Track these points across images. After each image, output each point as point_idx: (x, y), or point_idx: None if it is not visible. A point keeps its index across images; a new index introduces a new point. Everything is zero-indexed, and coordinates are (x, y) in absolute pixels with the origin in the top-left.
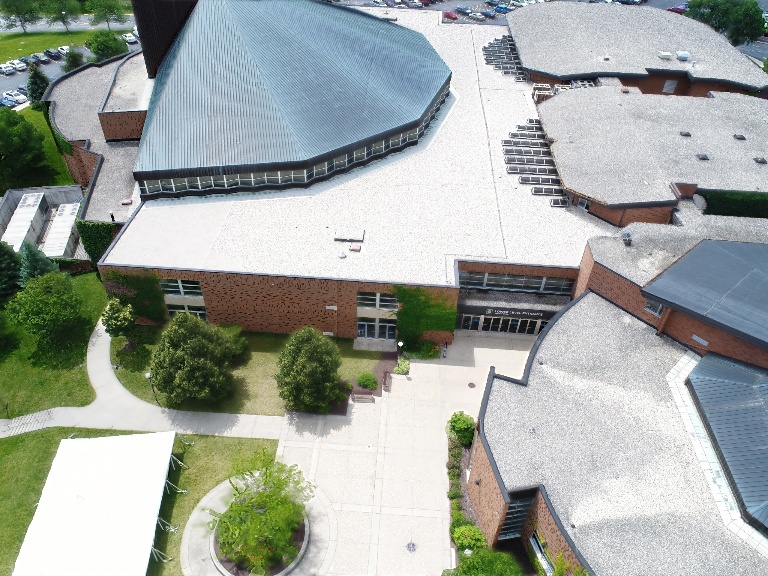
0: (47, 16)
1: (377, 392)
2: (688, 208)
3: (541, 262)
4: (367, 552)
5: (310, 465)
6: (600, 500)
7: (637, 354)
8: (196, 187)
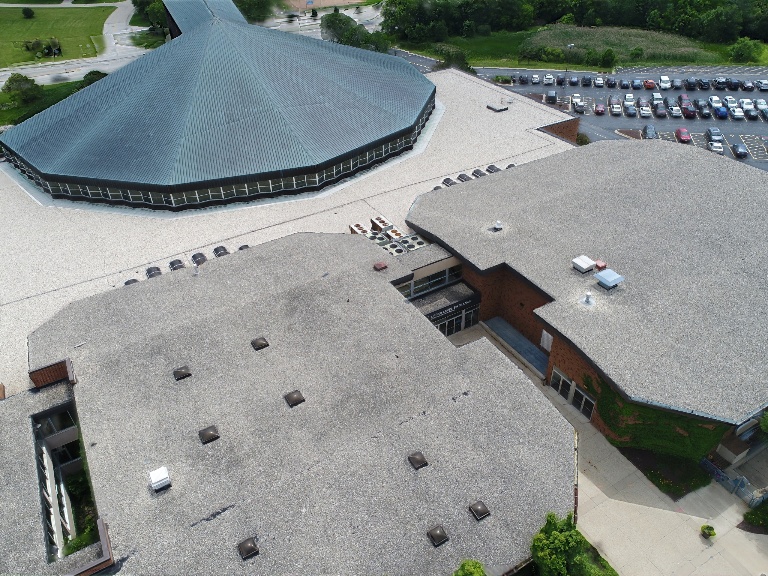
0: (346, 43)
1: None
2: (45, 399)
3: None
4: None
5: None
6: None
7: None
8: None
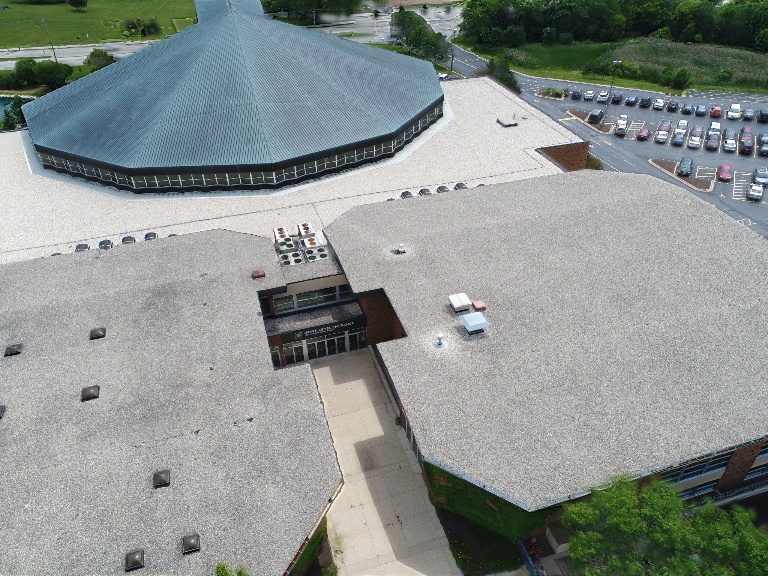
0: (412, 43)
1: None
2: None
3: None
4: None
5: None
6: None
7: None
8: None
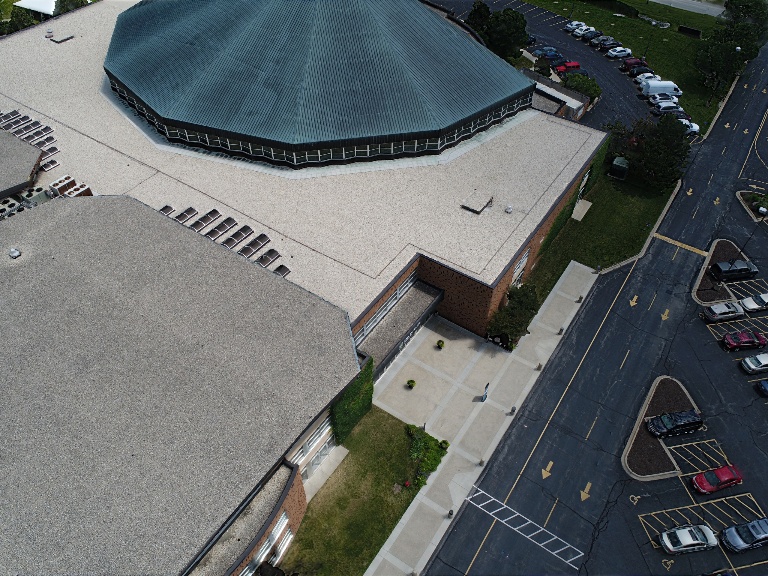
0: None
1: None
2: None
3: None
4: None
5: None
6: None
7: None
8: None
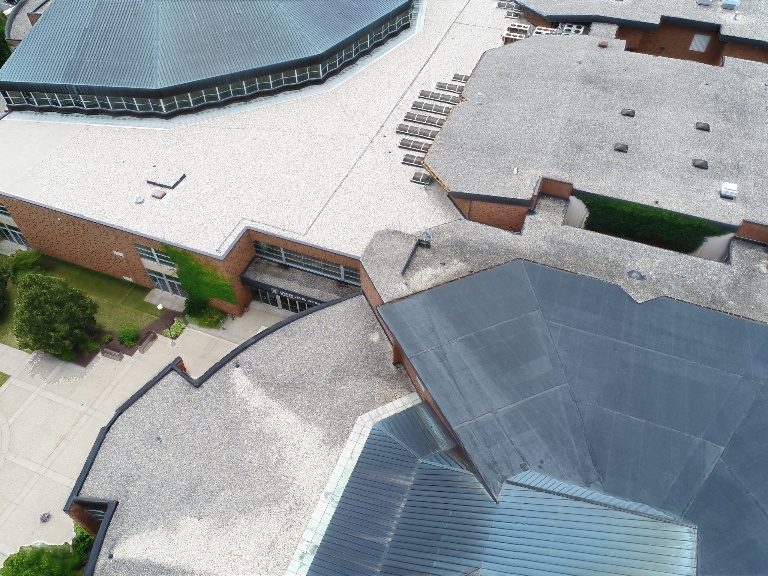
0: None
1: (131, 351)
2: (550, 212)
3: (338, 247)
4: (3, 509)
5: (18, 408)
6: (161, 537)
7: (350, 381)
8: (57, 104)
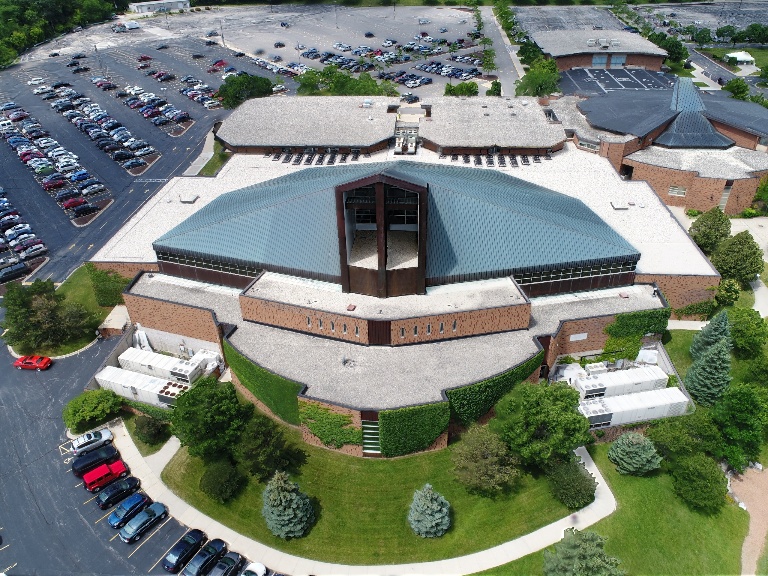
0: None
1: None
2: None
3: None
4: None
5: None
6: None
7: (659, 154)
8: None
